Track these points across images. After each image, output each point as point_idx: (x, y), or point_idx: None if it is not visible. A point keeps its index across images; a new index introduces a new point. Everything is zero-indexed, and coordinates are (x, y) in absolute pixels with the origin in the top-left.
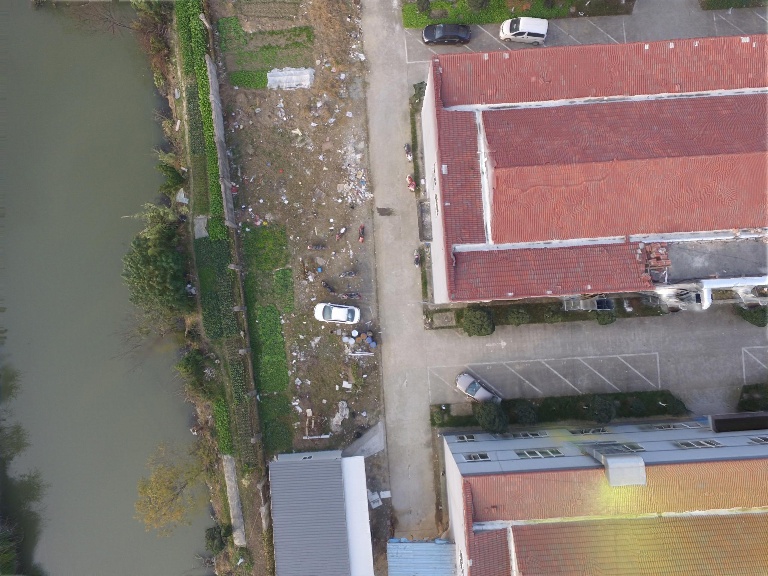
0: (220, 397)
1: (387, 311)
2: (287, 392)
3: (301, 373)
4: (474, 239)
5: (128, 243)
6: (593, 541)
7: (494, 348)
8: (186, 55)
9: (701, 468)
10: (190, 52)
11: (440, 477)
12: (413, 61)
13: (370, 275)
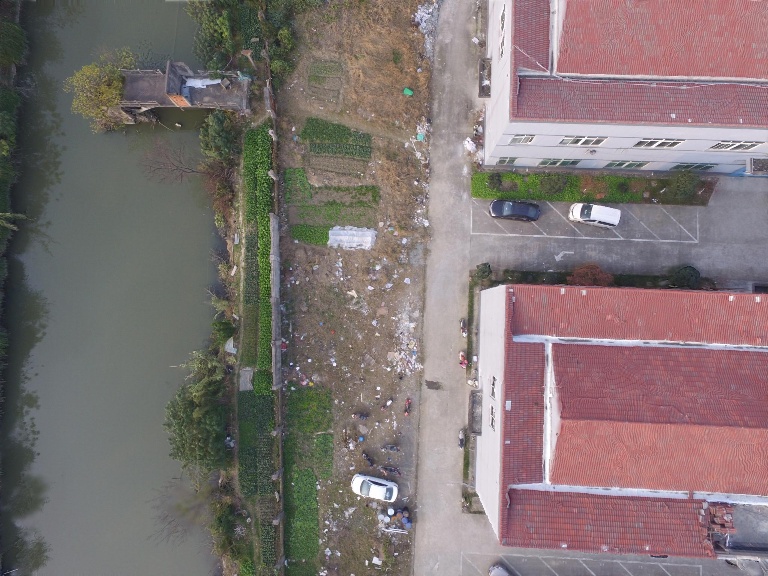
0: (248, 558)
1: (425, 489)
2: (316, 561)
3: (332, 543)
4: (531, 479)
5: (172, 383)
6: None
7: None
8: (250, 203)
9: None
10: (254, 200)
11: None
12: (477, 232)
13: (412, 449)
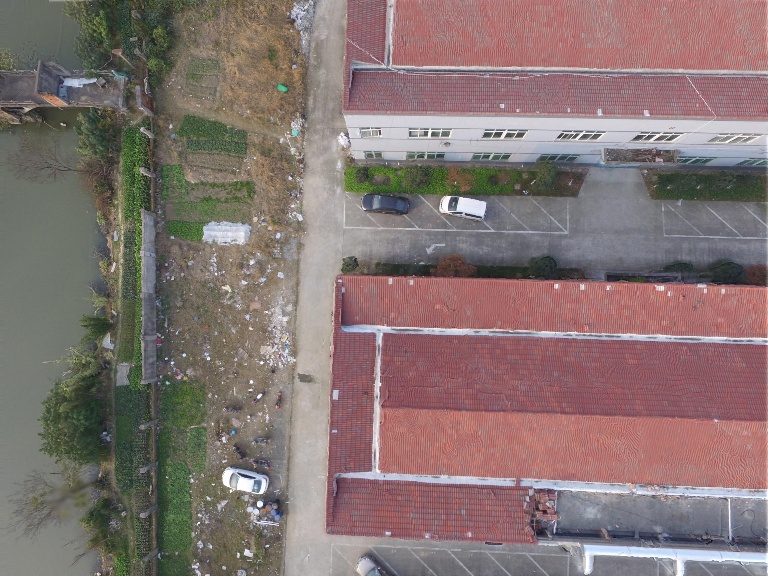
0: (122, 551)
1: (297, 481)
2: (188, 554)
3: (204, 536)
4: (359, 468)
5: None
6: None
7: None
8: (127, 200)
9: None
10: (132, 197)
11: None
12: (350, 226)
13: (284, 442)
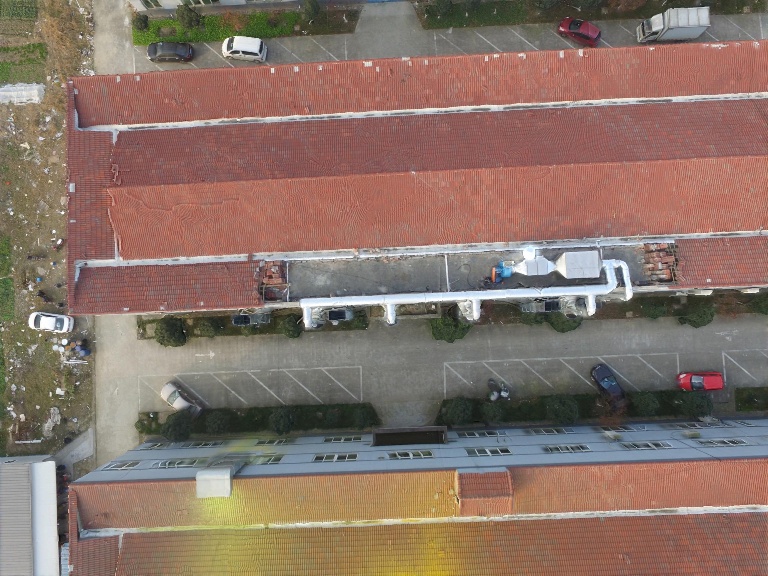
0: None
1: (103, 321)
2: (3, 397)
3: (17, 379)
4: (101, 255)
5: None
6: (195, 550)
7: (203, 358)
8: None
9: (293, 482)
10: None
11: None
12: None
13: None
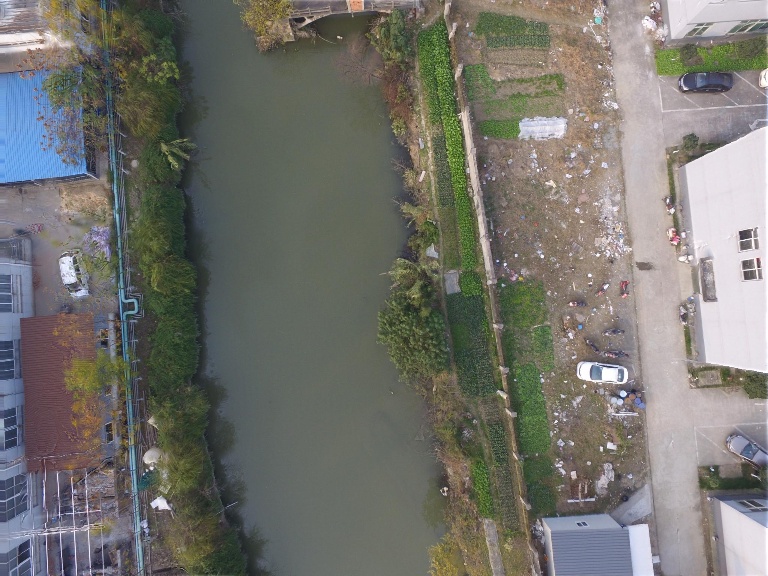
0: (480, 459)
1: (650, 369)
2: (549, 453)
3: (564, 434)
4: None
5: (371, 297)
6: None
7: (763, 408)
8: (433, 104)
9: None
10: (437, 101)
11: (711, 541)
12: (668, 110)
13: (632, 332)
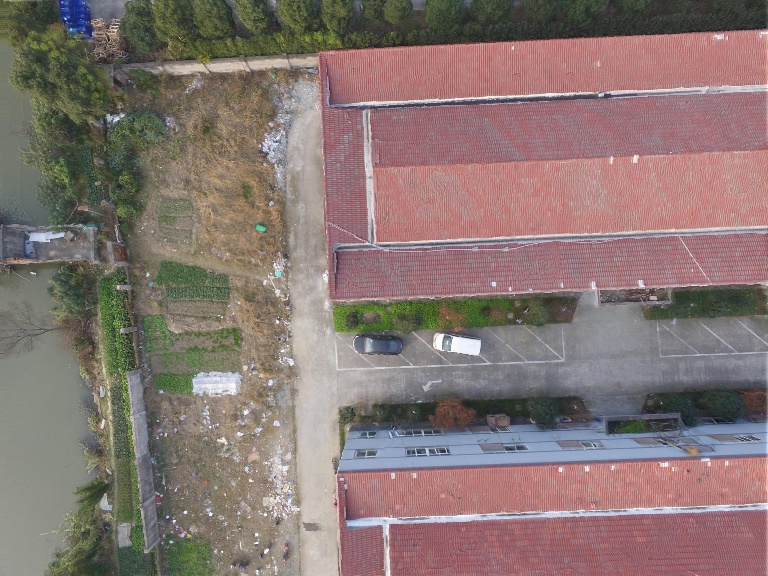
0: None
1: None
2: None
3: None
4: None
5: None
6: None
7: None
8: (110, 355)
9: None
10: (114, 352)
11: None
12: (343, 368)
13: None
